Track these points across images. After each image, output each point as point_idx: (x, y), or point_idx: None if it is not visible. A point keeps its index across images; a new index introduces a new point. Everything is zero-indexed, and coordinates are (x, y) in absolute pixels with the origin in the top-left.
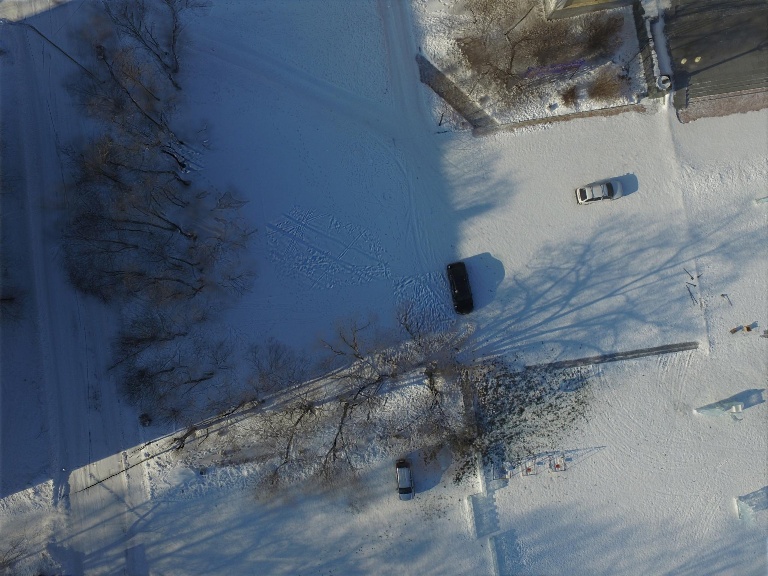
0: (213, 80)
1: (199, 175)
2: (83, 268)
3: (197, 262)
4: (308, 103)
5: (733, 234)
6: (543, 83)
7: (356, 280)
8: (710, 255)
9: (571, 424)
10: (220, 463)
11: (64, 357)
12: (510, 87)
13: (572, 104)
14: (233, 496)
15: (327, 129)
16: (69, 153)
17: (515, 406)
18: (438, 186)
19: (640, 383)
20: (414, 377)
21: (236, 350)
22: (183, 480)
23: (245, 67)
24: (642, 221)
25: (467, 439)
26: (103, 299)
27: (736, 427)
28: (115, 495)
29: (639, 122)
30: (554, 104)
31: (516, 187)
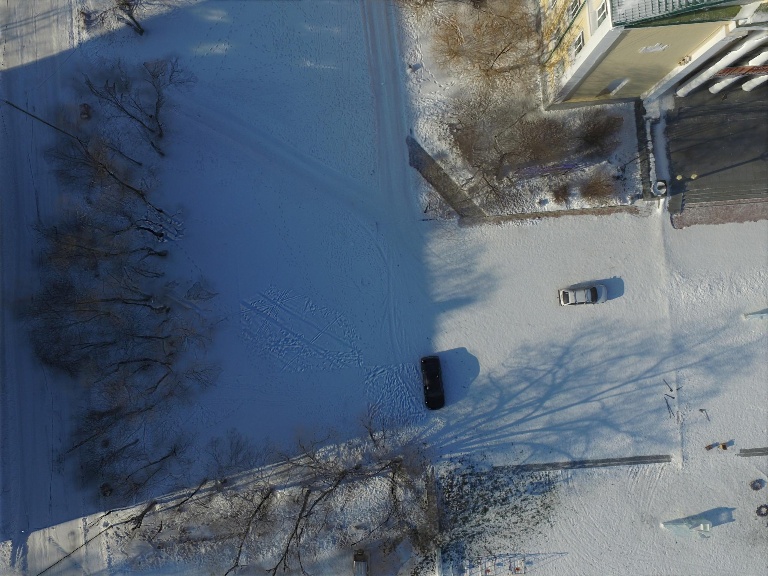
0: (197, 148)
1: (176, 245)
2: (49, 343)
3: (168, 335)
4: (292, 179)
5: (718, 348)
6: (535, 177)
7: (328, 366)
8: (692, 368)
9: (535, 528)
10: (178, 539)
11: (29, 420)
12: (500, 178)
13: (563, 201)
14: (190, 571)
15: (309, 208)
16: (40, 229)
17: (479, 505)
18: (418, 275)
19: (608, 492)
20: (379, 469)
21: (202, 427)
22: (140, 552)
23: (231, 136)
24: (625, 327)
25: (428, 535)
26: (69, 371)
27: (703, 544)
28: (73, 560)
29: (631, 224)
30: (544, 199)
31: (498, 282)
